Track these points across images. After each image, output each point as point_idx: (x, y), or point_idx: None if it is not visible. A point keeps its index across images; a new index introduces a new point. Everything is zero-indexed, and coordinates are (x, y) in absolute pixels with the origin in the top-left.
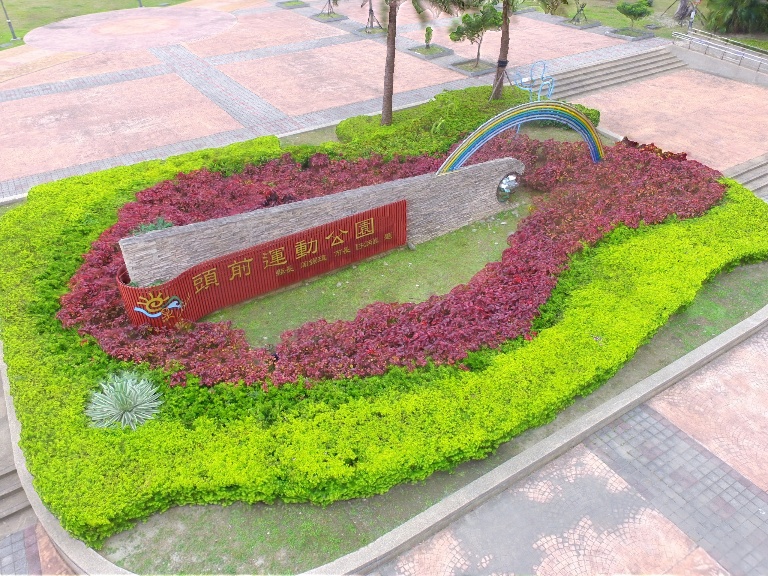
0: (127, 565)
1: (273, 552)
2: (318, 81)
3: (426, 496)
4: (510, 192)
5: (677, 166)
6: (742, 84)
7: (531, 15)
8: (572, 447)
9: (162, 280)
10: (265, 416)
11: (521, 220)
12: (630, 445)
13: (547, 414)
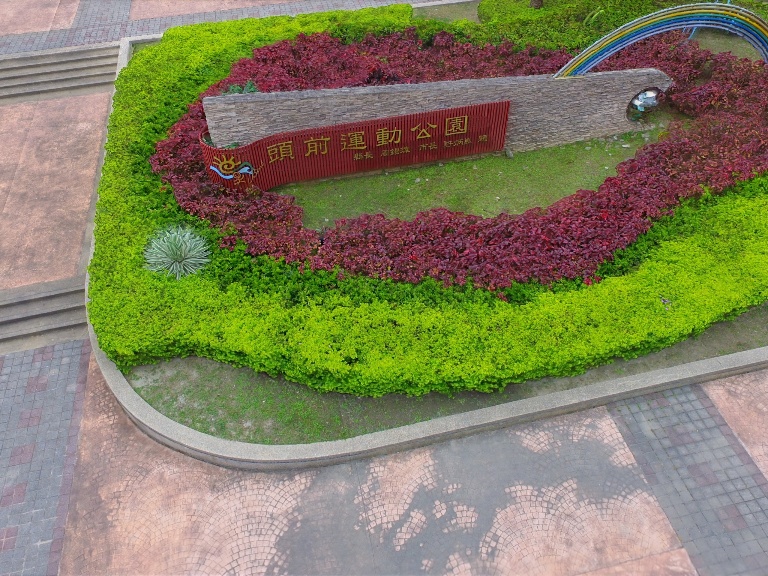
0: (143, 393)
1: (262, 419)
2: None
3: (418, 411)
4: (644, 111)
5: None
6: None
7: None
8: (592, 407)
9: (240, 144)
10: (292, 296)
11: (643, 146)
12: (658, 423)
13: (573, 367)
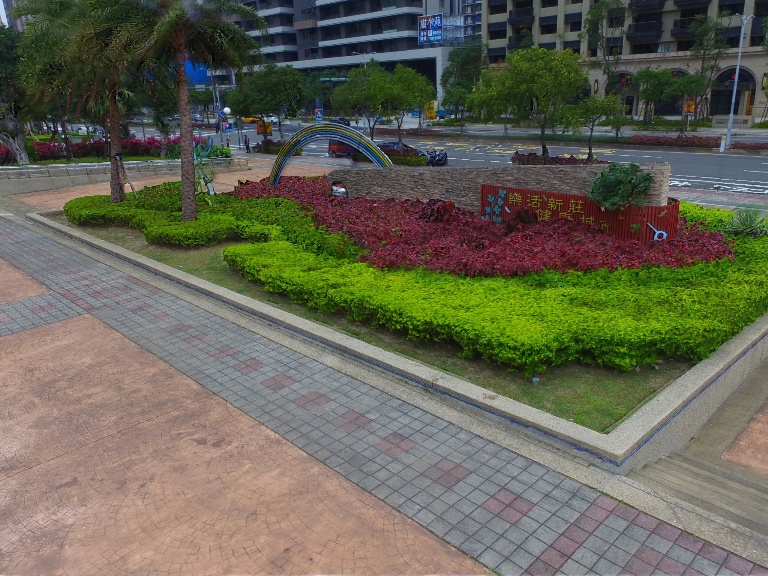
0: None
1: None
2: None
3: None
4: None
5: None
6: (74, 187)
7: None
8: None
9: None
10: None
11: None
12: None
13: None
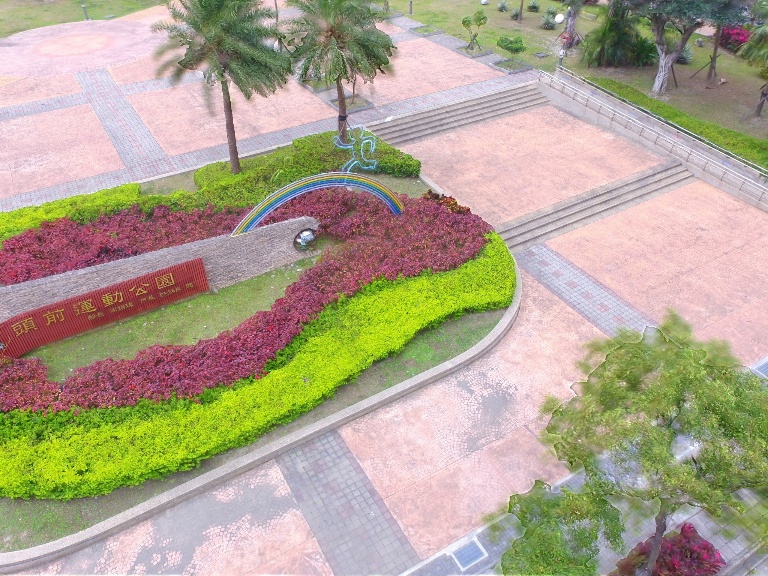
0: None
1: (19, 533)
2: (209, 116)
3: (140, 496)
4: (305, 245)
5: (458, 220)
6: (585, 125)
7: (437, 38)
8: (266, 462)
9: None
10: (38, 436)
11: (304, 271)
12: (308, 462)
13: (245, 438)
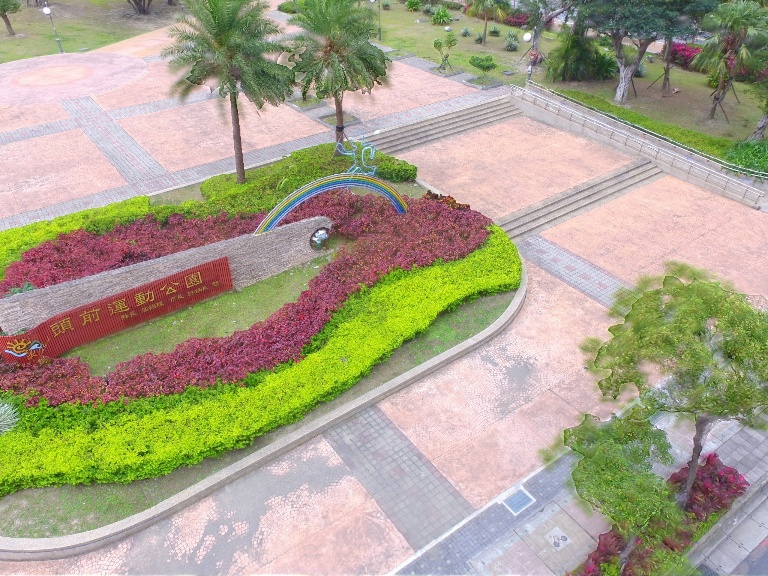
0: None
1: (85, 515)
2: (202, 136)
3: (199, 475)
4: (321, 243)
5: (460, 216)
6: (558, 131)
7: (409, 61)
8: (314, 437)
9: (27, 329)
10: (91, 425)
11: (323, 266)
12: (354, 434)
13: (294, 415)
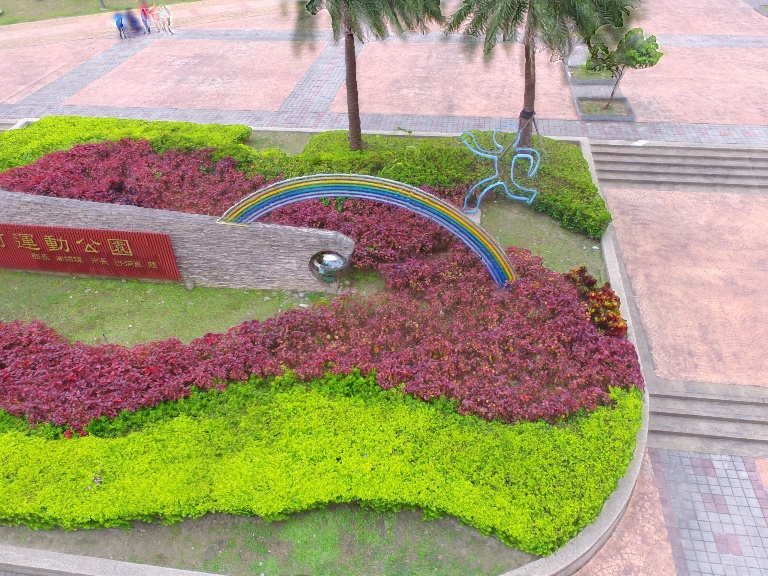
0: None
1: None
2: (418, 81)
3: None
4: (323, 273)
5: (584, 339)
6: None
7: None
8: None
9: None
10: None
11: (287, 310)
12: None
13: None
